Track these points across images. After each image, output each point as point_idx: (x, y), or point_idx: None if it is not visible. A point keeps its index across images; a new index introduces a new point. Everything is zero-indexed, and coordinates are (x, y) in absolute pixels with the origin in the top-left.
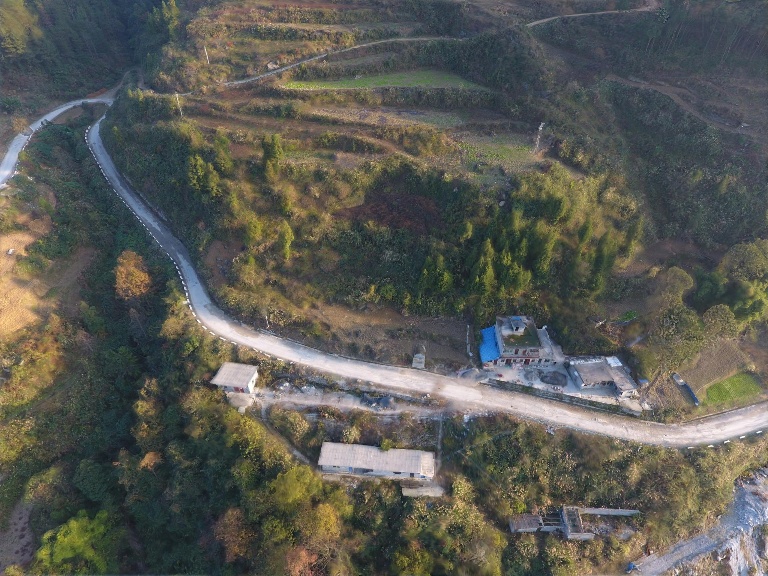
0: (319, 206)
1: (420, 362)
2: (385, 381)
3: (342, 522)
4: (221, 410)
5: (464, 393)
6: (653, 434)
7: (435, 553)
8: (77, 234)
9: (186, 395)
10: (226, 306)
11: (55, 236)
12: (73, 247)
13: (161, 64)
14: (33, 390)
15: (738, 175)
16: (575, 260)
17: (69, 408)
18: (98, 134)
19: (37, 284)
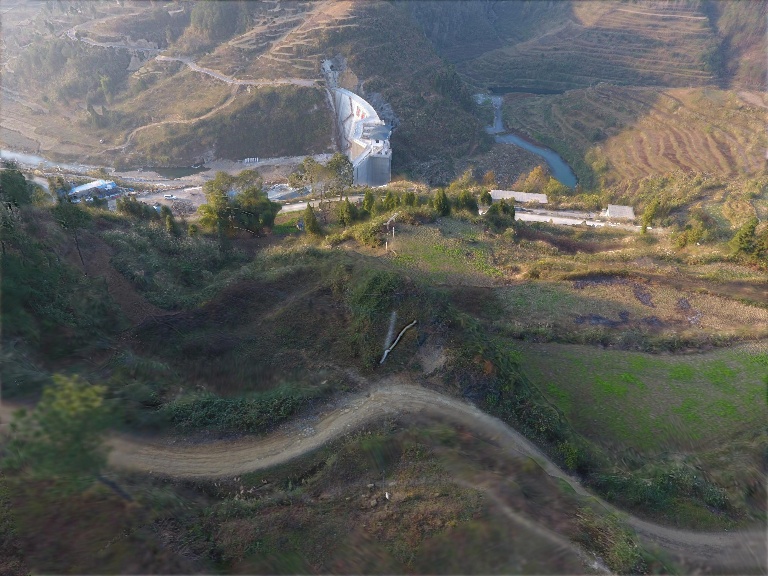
0: None
1: None
2: (521, 215)
3: None
4: None
5: None
6: (356, 199)
7: None
8: None
9: None
10: None
11: None
12: None
13: None
14: None
15: None
16: None
17: None
18: None
19: None
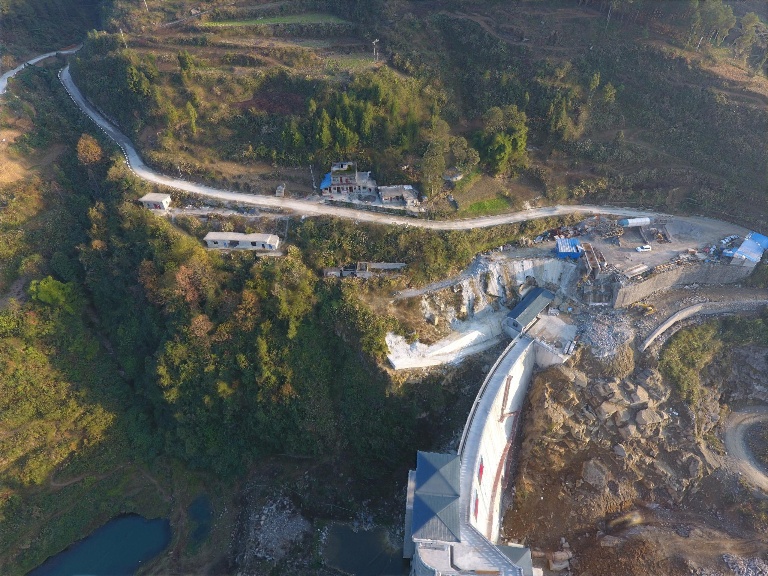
0: (220, 101)
1: (281, 192)
2: (255, 202)
3: (216, 269)
4: None
5: (306, 207)
6: (424, 225)
7: (270, 281)
8: (52, 133)
9: None
10: (152, 163)
11: (36, 133)
12: (49, 142)
13: (112, 13)
14: (23, 216)
15: (515, 73)
16: (386, 124)
17: (47, 228)
18: (68, 73)
19: (23, 161)
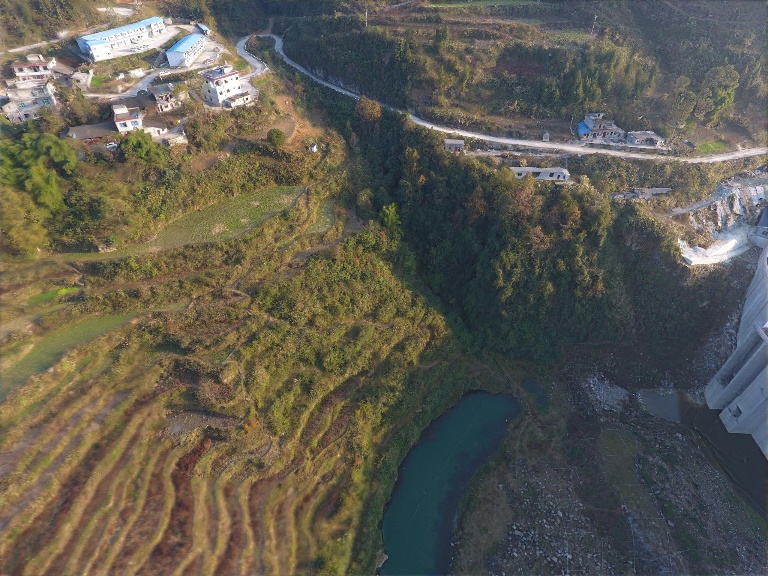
0: (472, 67)
1: (547, 138)
2: (532, 145)
3: None
4: (455, 154)
5: (574, 149)
6: None
7: (579, 201)
8: None
9: (432, 151)
10: (434, 116)
11: (304, 97)
12: None
13: None
14: (339, 160)
15: (708, 43)
16: (625, 82)
17: (358, 171)
18: None
19: None
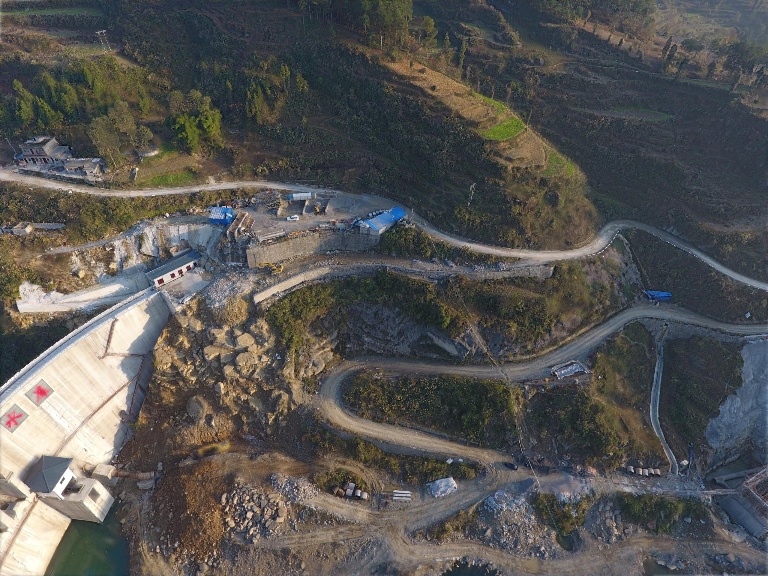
0: None
1: None
2: None
3: None
4: None
5: None
6: (95, 192)
7: None
8: None
9: None
10: None
11: None
12: None
13: None
14: None
15: (229, 64)
16: (86, 104)
17: None
18: None
19: None
